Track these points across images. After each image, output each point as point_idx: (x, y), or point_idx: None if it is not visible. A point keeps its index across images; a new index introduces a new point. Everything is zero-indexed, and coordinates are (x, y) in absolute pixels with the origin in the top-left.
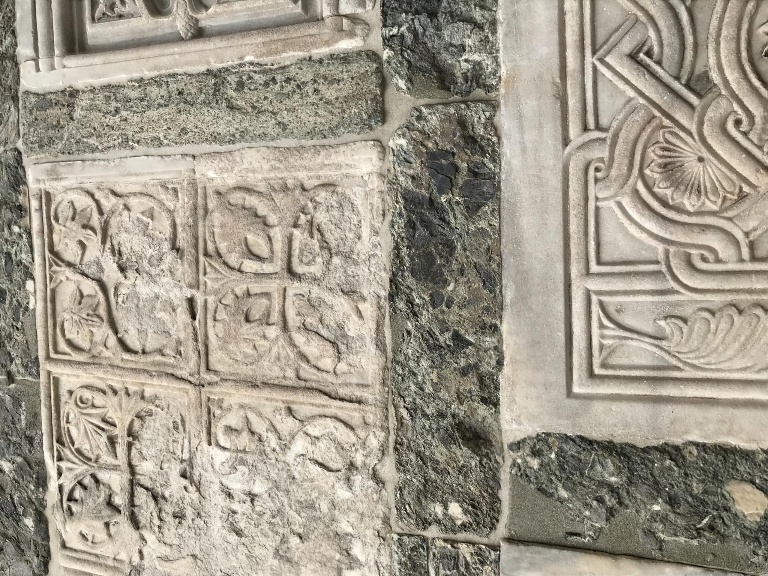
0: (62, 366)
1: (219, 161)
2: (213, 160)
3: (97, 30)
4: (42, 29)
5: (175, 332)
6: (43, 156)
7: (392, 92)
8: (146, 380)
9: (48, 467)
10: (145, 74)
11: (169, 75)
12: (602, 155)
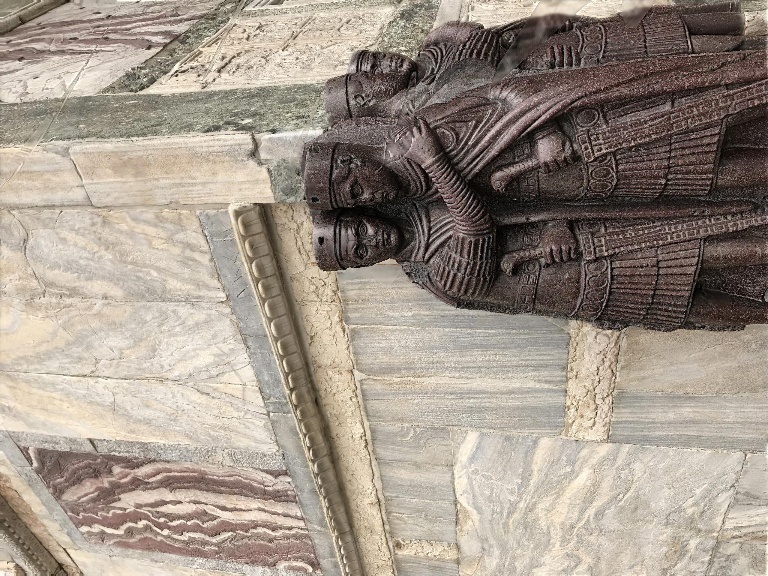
0: (210, 47)
1: (327, 11)
2: (324, 11)
3: (288, 2)
4: (262, 2)
5: (281, 37)
6: (242, 17)
7: (404, 0)
8: (258, 44)
9: (172, 70)
10: (303, 5)
11: (314, 4)
12: (476, 0)
